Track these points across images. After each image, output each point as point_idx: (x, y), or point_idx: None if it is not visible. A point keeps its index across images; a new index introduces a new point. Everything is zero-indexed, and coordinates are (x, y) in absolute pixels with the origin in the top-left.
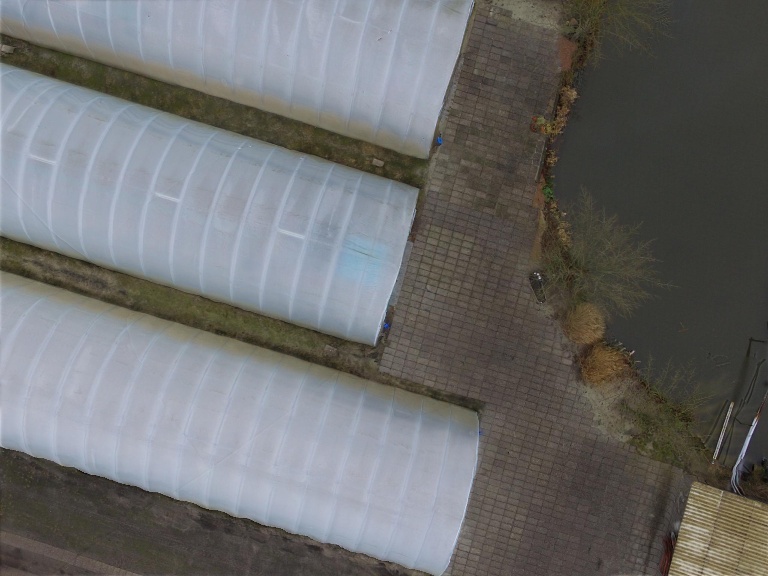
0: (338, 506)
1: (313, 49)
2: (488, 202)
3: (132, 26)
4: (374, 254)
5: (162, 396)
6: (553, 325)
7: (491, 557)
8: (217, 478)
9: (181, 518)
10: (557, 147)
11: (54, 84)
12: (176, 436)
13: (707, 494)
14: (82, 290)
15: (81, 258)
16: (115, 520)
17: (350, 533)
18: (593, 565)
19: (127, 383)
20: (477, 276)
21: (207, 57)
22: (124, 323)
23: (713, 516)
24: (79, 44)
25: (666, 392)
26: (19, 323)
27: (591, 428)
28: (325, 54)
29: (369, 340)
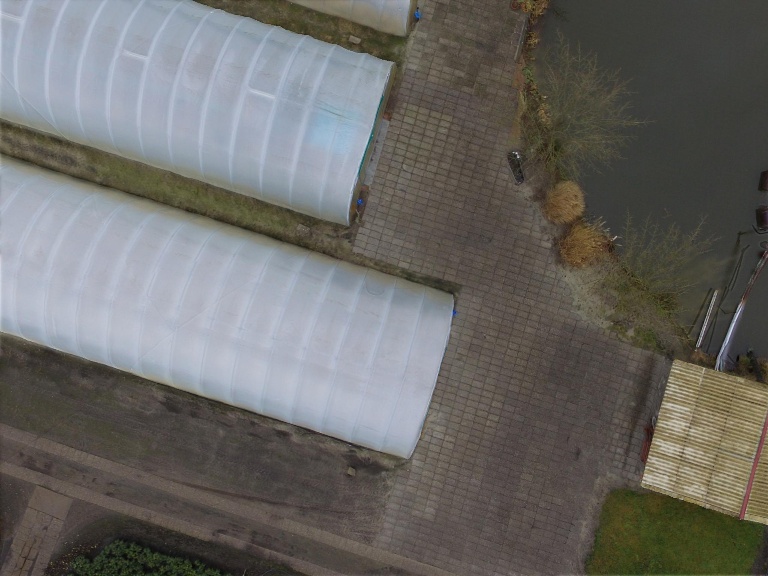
0: (305, 373)
1: None
2: (466, 81)
3: None
4: (346, 114)
5: (125, 257)
6: (532, 207)
7: (466, 445)
8: (180, 342)
9: (146, 400)
10: (537, 30)
11: None
12: (139, 297)
13: (688, 371)
14: (50, 164)
15: (50, 130)
16: (78, 401)
17: (317, 404)
18: (572, 455)
19: (90, 243)
20: (454, 156)
21: None
22: (91, 192)
23: (694, 394)
24: None
25: (648, 279)
26: None
27: (570, 313)
28: None
29: (343, 219)
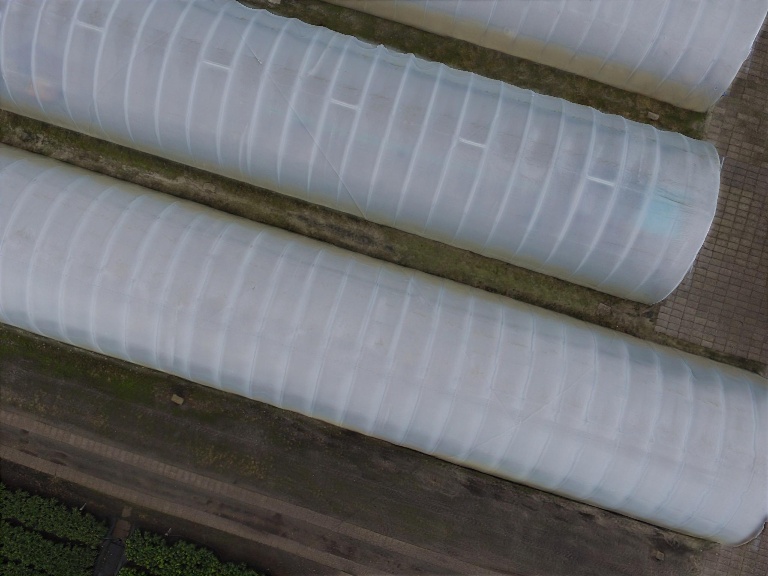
0: (650, 466)
1: None
2: (766, 157)
3: None
4: (686, 202)
5: (465, 348)
6: None
7: None
8: (523, 435)
9: (449, 483)
10: None
11: (336, 32)
12: (483, 390)
13: None
14: (348, 245)
15: (351, 211)
16: (380, 485)
17: (657, 496)
18: None
19: (429, 334)
20: (756, 233)
21: (500, 3)
22: (405, 276)
23: None
24: None
25: None
26: (311, 272)
27: None
28: None
29: (646, 298)
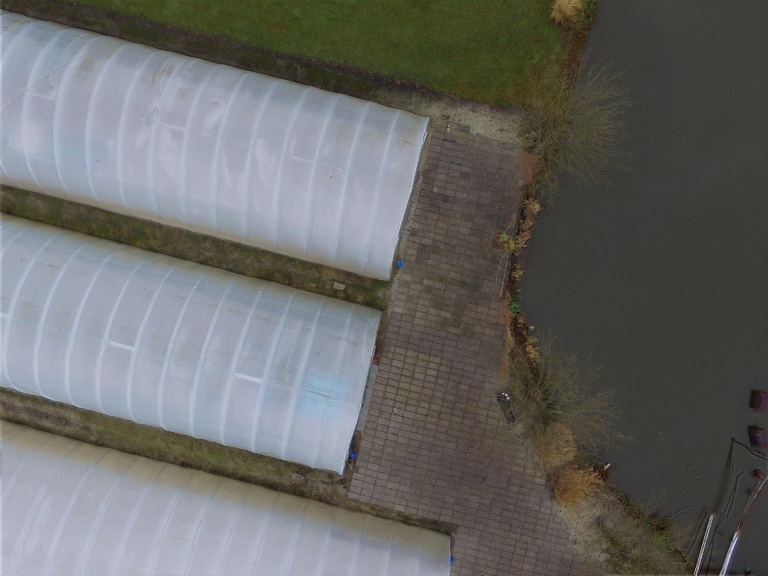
0: None
1: (264, 188)
2: (453, 321)
3: (81, 170)
4: (333, 396)
5: (124, 547)
6: (524, 444)
7: None
8: None
9: None
10: (522, 260)
11: (7, 226)
12: None
13: None
14: (46, 426)
15: (43, 396)
16: None
17: None
18: None
19: (89, 535)
20: (444, 397)
21: (159, 197)
22: (87, 465)
23: None
24: (32, 182)
25: (643, 506)
26: None
27: (567, 548)
28: (276, 193)
29: None
